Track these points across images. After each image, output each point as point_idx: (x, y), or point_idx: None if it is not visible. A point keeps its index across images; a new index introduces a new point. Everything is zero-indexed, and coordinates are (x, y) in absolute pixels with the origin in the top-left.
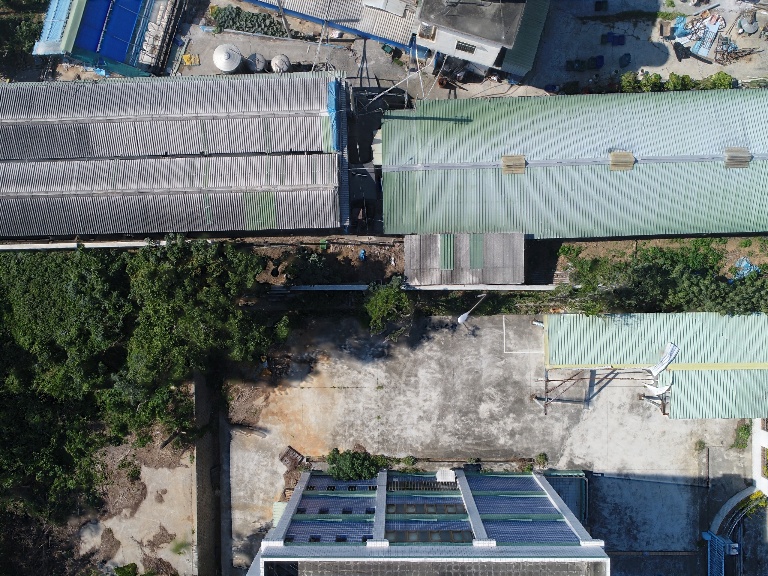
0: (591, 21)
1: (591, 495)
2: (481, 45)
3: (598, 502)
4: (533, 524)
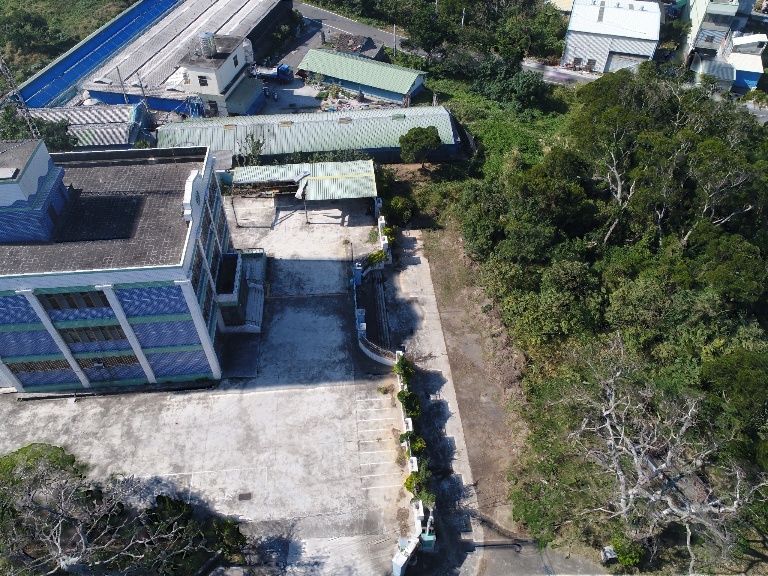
0: (287, 109)
1: (272, 269)
2: (207, 75)
3: (277, 272)
4: None
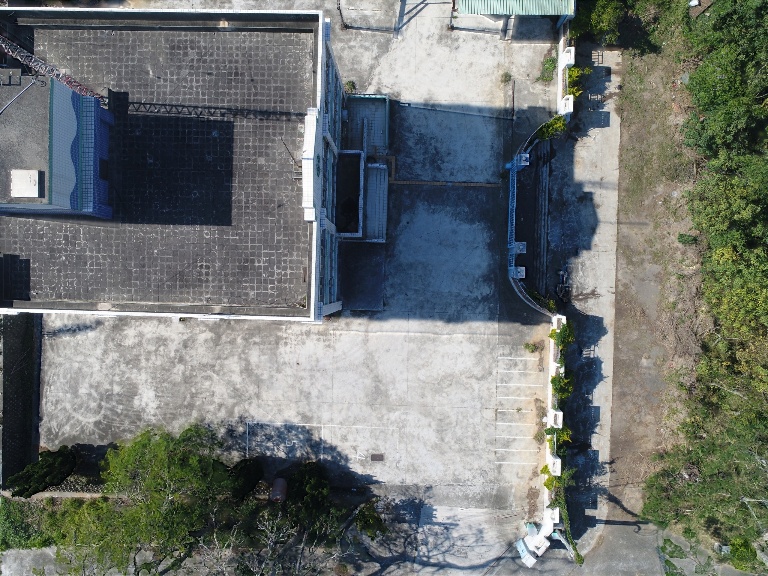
0: None
1: (397, 125)
2: None
3: (404, 132)
4: None
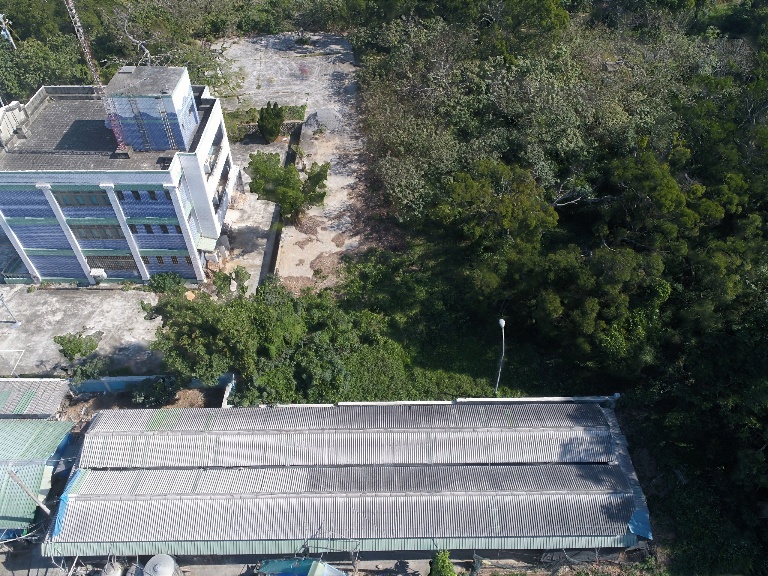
0: None
1: None
2: None
3: (6, 269)
4: (24, 214)
